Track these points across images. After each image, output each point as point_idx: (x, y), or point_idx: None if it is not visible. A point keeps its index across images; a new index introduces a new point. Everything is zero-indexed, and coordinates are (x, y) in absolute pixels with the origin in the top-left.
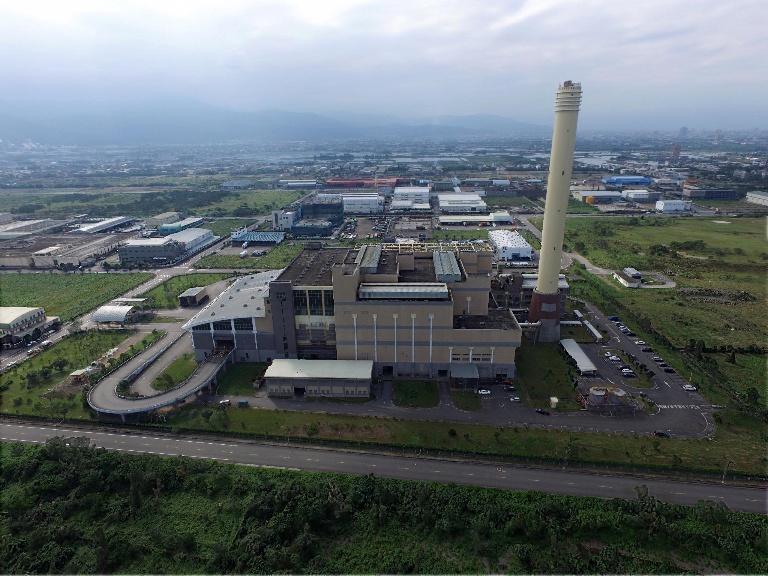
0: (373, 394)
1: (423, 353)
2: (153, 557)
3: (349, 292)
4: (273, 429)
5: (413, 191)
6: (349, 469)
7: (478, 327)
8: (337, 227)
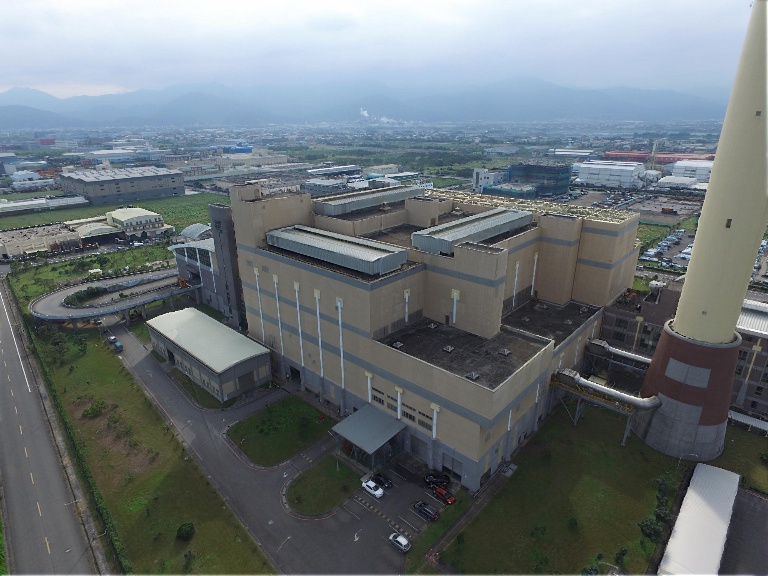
0: (234, 400)
1: (334, 366)
2: None
3: (248, 230)
4: (78, 389)
5: (707, 165)
6: (16, 493)
7: (428, 353)
8: (549, 197)
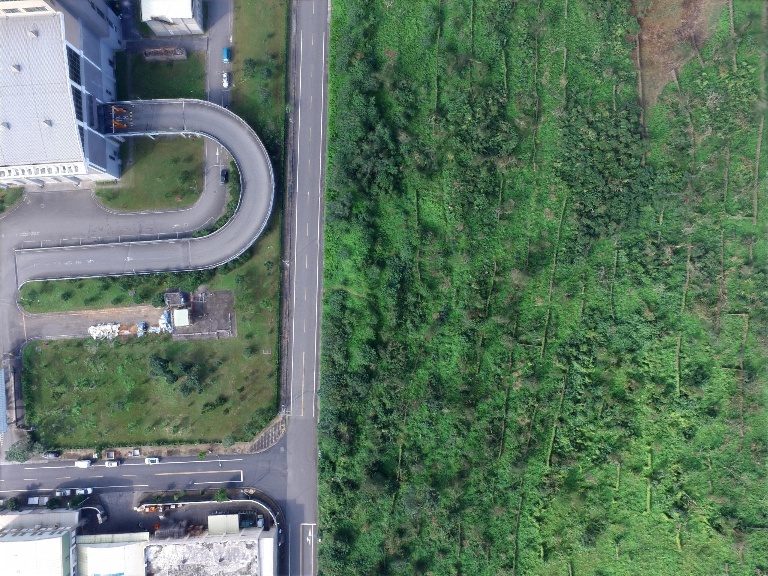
0: None
1: None
2: (454, 22)
3: None
4: (272, 1)
5: None
6: None
7: None
8: None
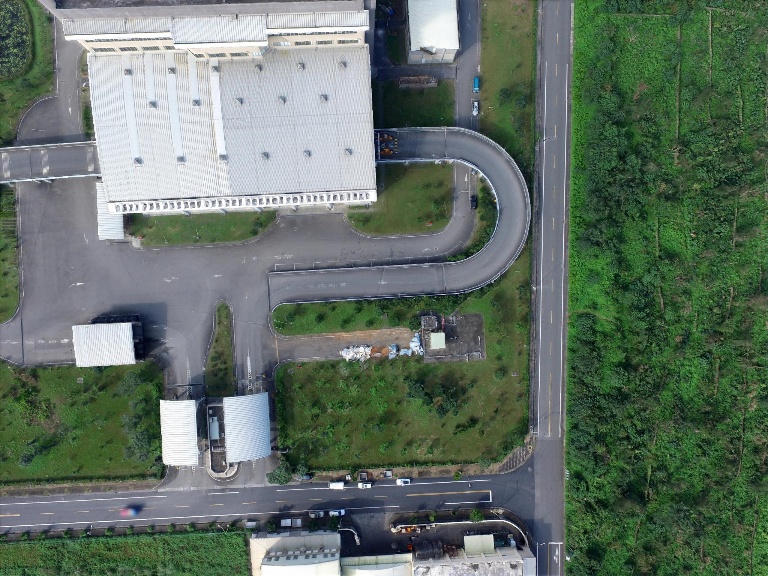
0: None
1: None
2: None
3: None
4: (519, 32)
5: None
6: None
7: None
8: None
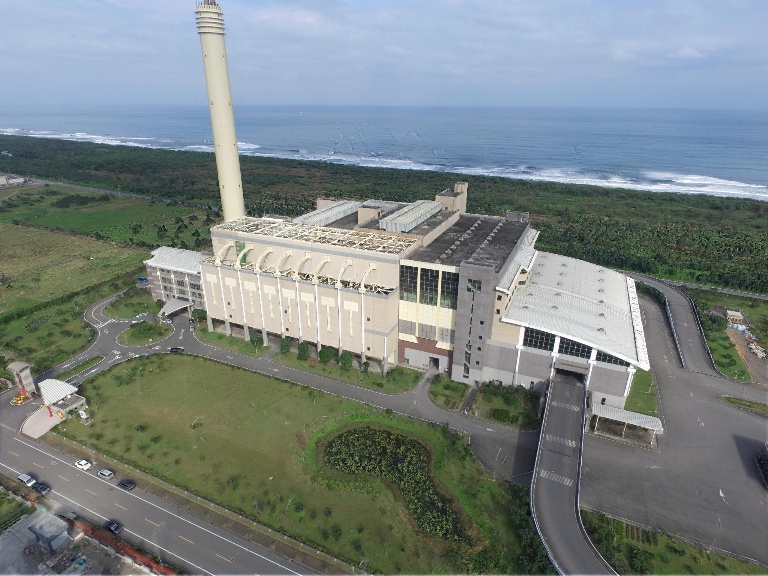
0: None
1: None
2: None
3: None
4: None
5: None
6: None
7: None
8: None
